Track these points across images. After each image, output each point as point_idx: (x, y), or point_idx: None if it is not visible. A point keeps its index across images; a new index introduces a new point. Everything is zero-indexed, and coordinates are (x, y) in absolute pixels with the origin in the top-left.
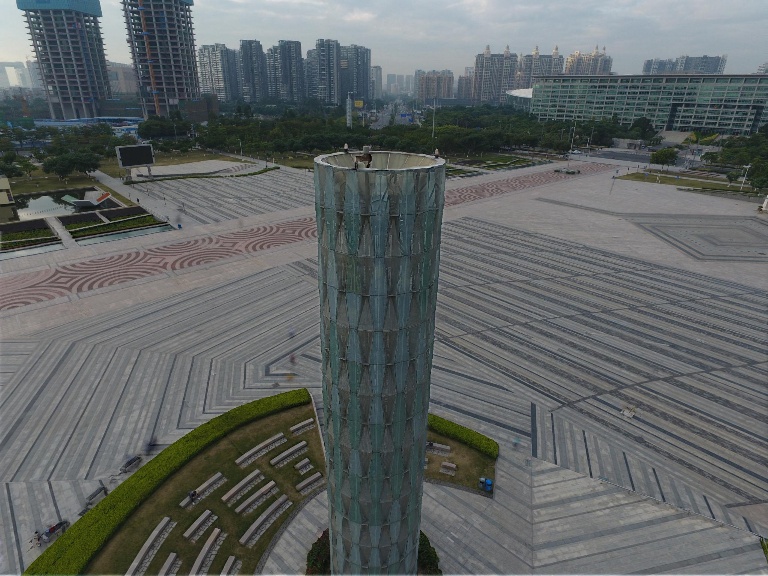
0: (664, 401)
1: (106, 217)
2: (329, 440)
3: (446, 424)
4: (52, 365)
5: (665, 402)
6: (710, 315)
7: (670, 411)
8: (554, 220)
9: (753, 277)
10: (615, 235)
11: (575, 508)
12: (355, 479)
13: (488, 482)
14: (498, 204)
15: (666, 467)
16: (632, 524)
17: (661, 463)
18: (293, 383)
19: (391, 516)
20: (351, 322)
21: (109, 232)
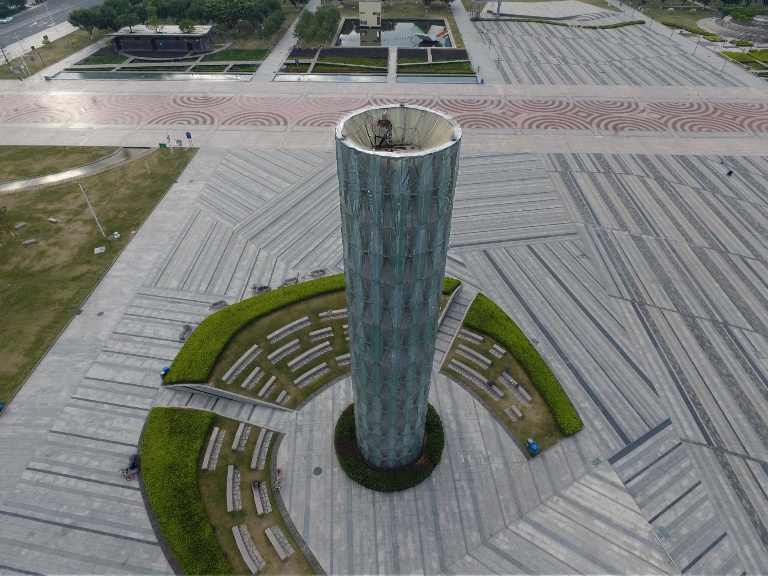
0: None
1: (432, 56)
2: None
3: (547, 379)
4: (322, 181)
5: None
6: None
7: None
8: None
9: None
10: None
11: (596, 525)
12: None
13: (533, 446)
14: None
15: None
16: None
17: None
18: (456, 271)
19: (374, 404)
20: (346, 256)
21: (424, 73)
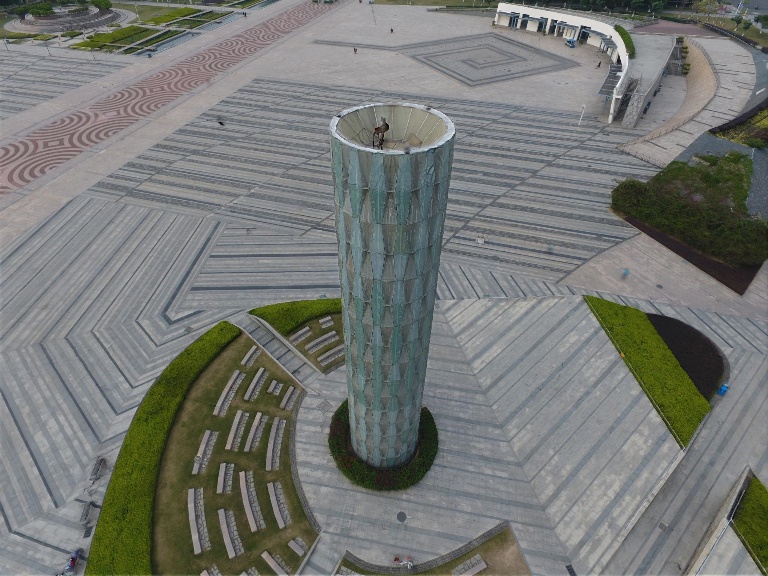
0: (497, 222)
1: None
2: (365, 366)
3: None
4: None
5: (498, 223)
6: (497, 139)
7: (504, 229)
8: (343, 66)
9: (511, 95)
10: (401, 74)
11: (481, 324)
12: (393, 383)
13: None
14: (280, 56)
15: (517, 271)
16: (517, 319)
17: (513, 270)
18: (205, 320)
19: (417, 394)
20: (397, 276)
21: None
